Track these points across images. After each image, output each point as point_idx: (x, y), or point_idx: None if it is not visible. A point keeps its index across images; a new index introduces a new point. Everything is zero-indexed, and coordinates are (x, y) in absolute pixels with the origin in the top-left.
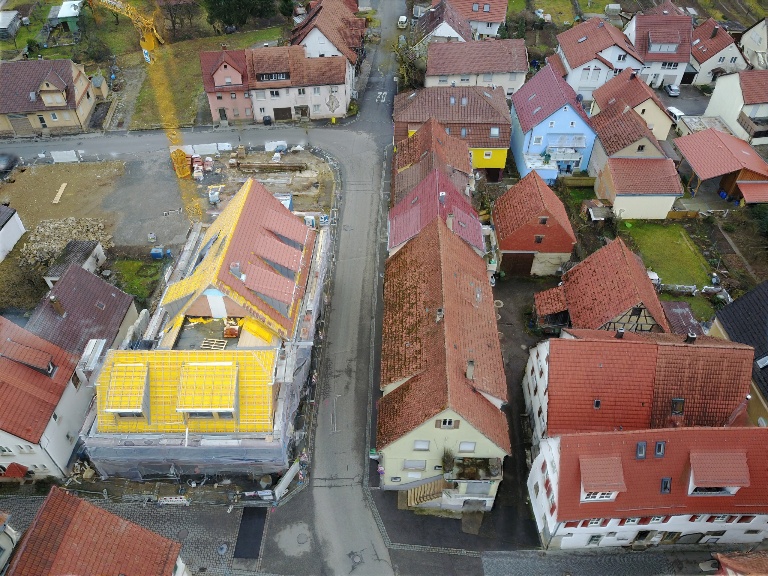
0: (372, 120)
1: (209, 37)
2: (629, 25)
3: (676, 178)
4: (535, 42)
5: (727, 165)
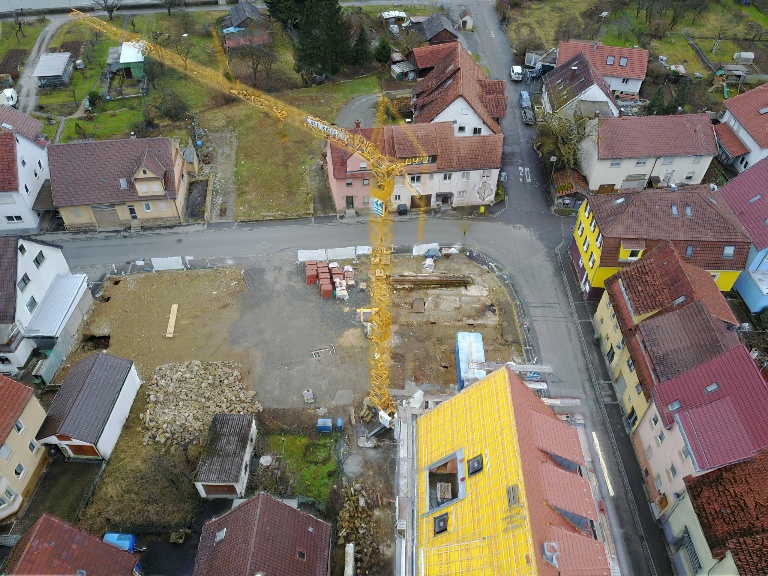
0: (526, 208)
1: (298, 89)
2: None
3: None
4: None
5: None
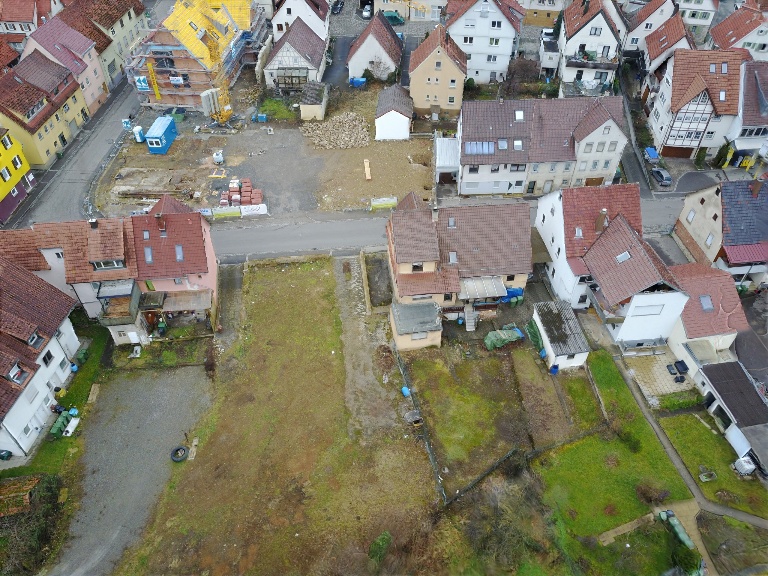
0: None
1: None
2: None
3: None
4: None
5: None
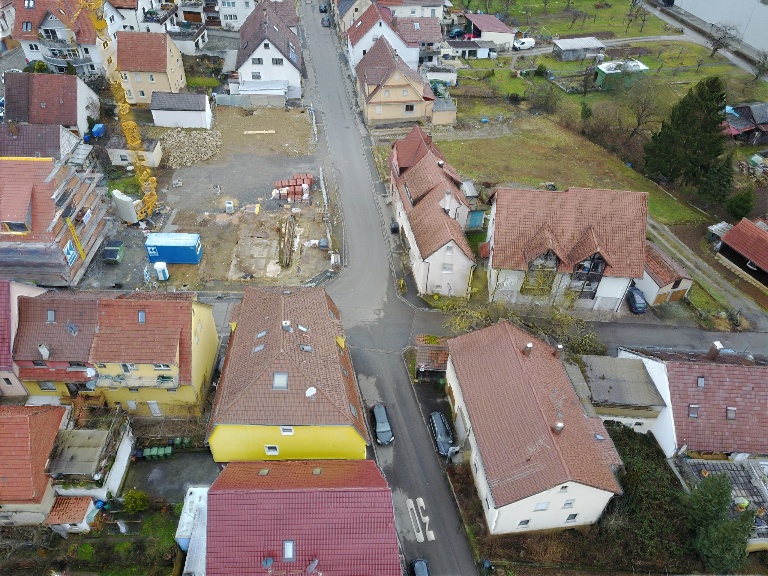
0: (416, 324)
1: (624, 163)
2: None
3: None
4: None
5: None
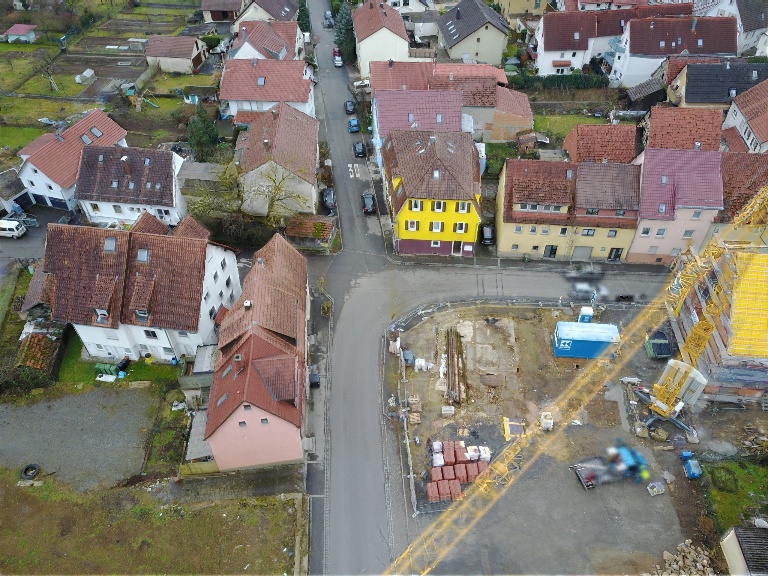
0: (323, 272)
1: None
2: (237, 55)
3: (512, 91)
4: (144, 135)
5: (484, 72)
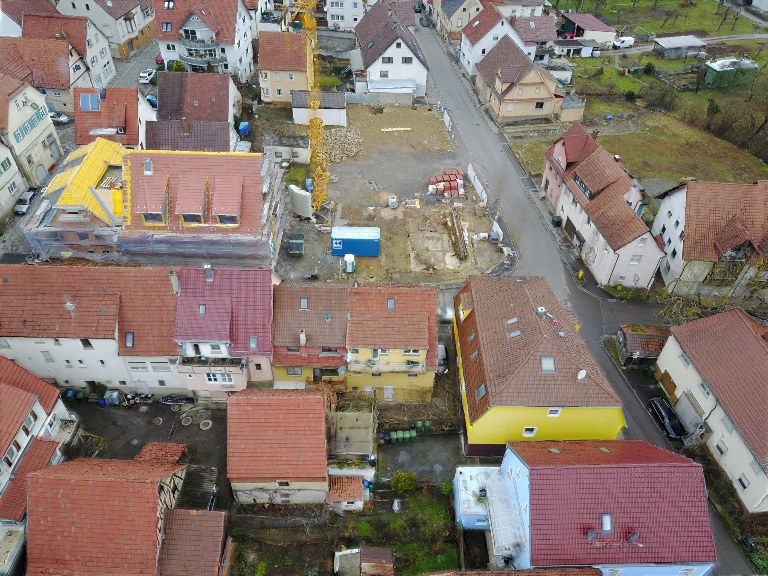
0: (605, 313)
1: (758, 159)
2: None
3: None
4: None
5: None
